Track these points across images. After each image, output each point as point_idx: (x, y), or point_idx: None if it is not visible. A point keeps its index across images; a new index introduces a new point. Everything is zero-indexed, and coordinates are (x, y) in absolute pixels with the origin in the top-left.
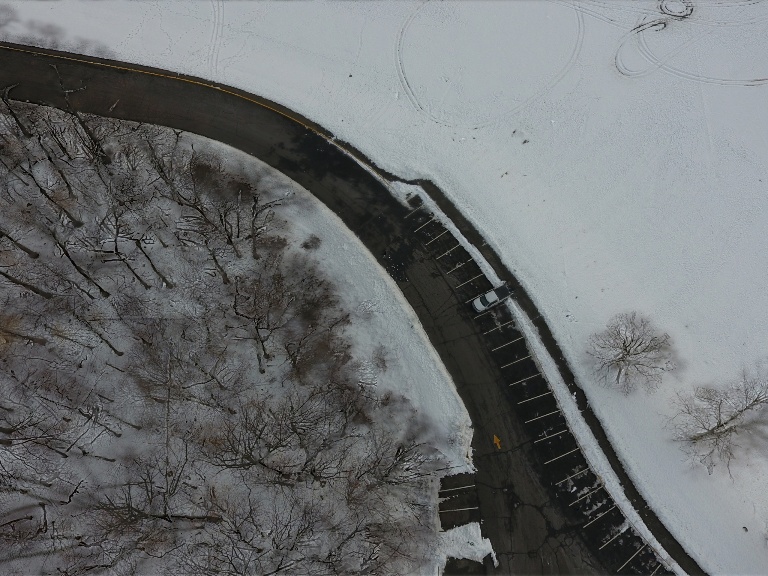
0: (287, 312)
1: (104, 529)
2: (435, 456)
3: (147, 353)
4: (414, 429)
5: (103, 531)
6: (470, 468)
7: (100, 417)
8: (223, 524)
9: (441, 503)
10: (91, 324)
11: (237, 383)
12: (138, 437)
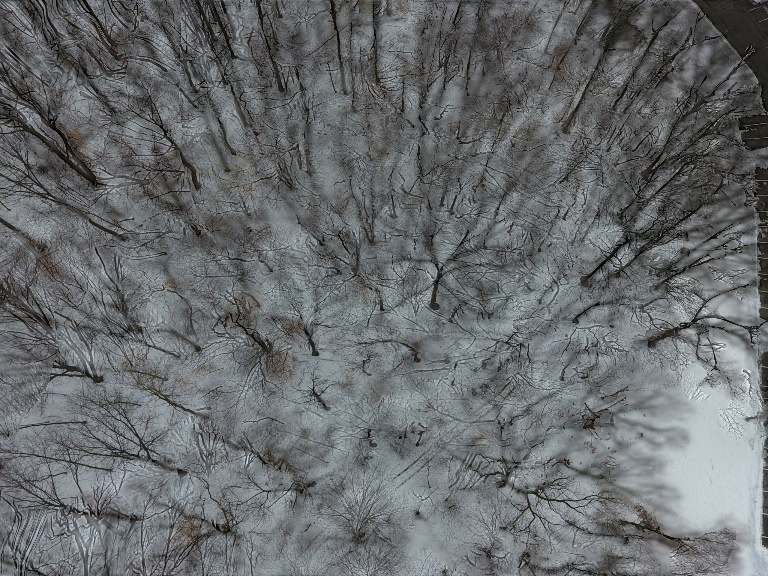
0: (589, 2)
1: (480, 130)
2: (747, 86)
3: (478, 25)
4: (710, 86)
5: (480, 132)
6: (763, 111)
7: (449, 67)
8: (573, 134)
9: (742, 134)
10: (426, 4)
11: (558, 49)
12: (485, 80)
